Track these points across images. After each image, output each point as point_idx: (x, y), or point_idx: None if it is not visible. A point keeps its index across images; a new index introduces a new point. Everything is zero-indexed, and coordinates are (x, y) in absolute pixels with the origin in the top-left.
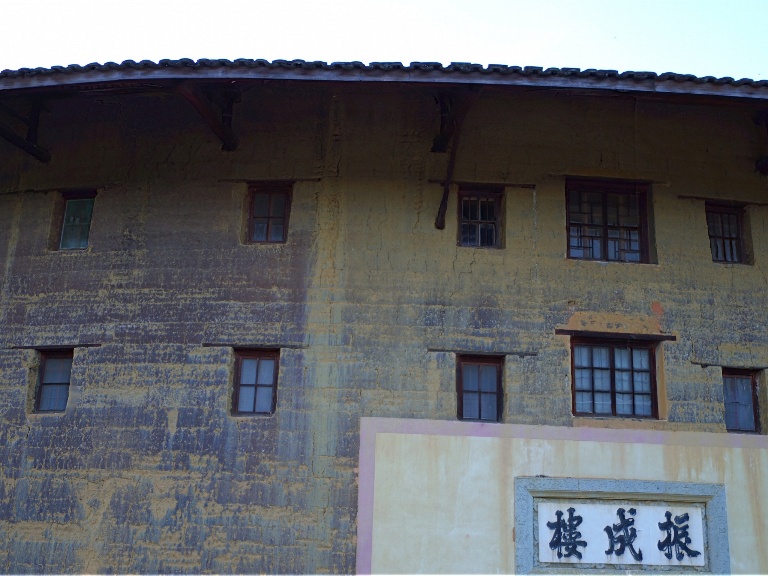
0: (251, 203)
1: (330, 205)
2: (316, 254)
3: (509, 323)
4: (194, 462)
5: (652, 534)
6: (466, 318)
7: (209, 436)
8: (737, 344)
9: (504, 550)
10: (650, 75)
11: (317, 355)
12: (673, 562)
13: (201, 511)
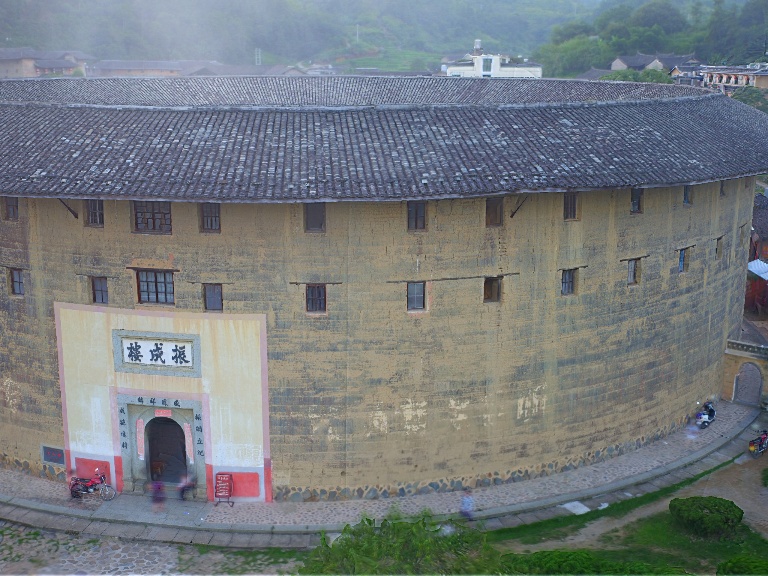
0: (6, 198)
1: (32, 205)
2: (30, 228)
3: (107, 264)
4: (1, 313)
5: (169, 353)
6: (89, 261)
7: (4, 304)
8: (209, 273)
9: (110, 357)
10: (96, 193)
11: (35, 274)
12: (178, 365)
13: (6, 333)
